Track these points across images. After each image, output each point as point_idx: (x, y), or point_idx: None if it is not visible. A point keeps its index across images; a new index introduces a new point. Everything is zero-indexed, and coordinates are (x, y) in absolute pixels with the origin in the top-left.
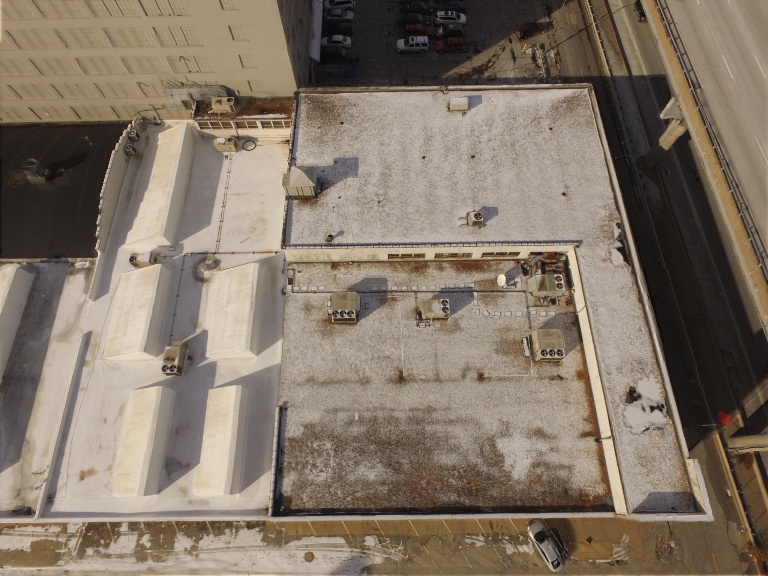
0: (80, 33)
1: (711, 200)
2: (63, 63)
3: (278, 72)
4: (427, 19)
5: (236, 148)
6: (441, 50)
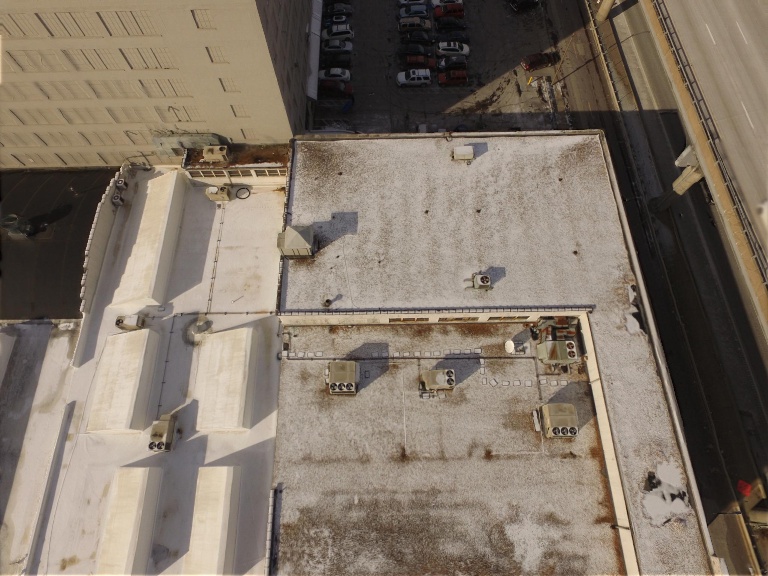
0: (62, 85)
1: (727, 246)
2: (45, 113)
3: (273, 120)
4: (429, 50)
5: (229, 197)
6: (443, 83)
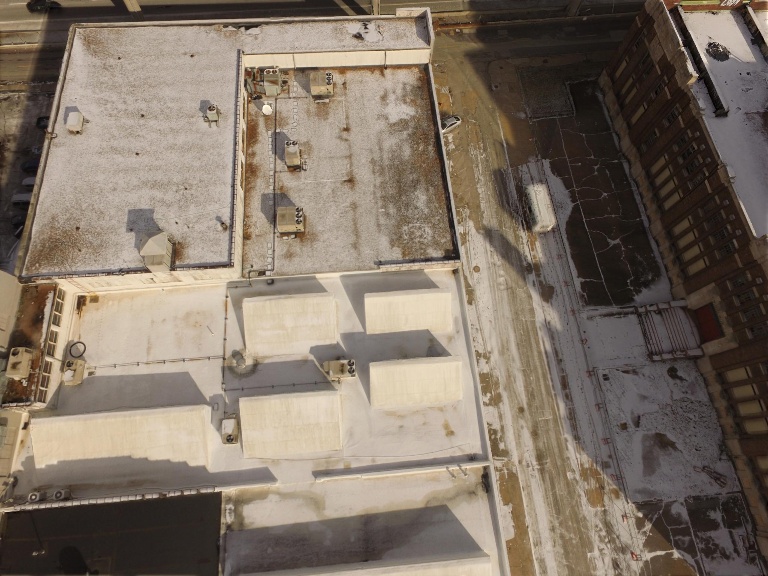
0: None
1: (188, 3)
2: None
3: None
4: None
5: (81, 361)
6: None
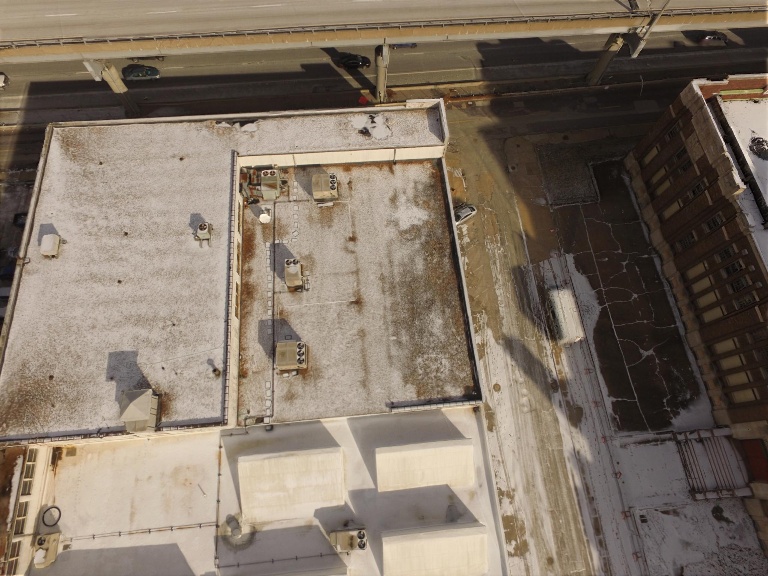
0: None
1: (179, 74)
2: None
3: None
4: None
5: (54, 533)
6: None
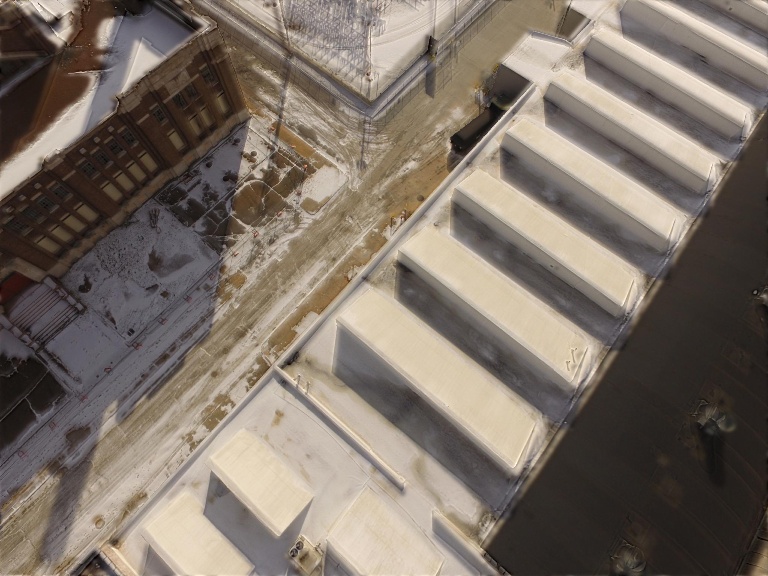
0: None
1: None
2: None
3: None
4: None
5: None
6: None
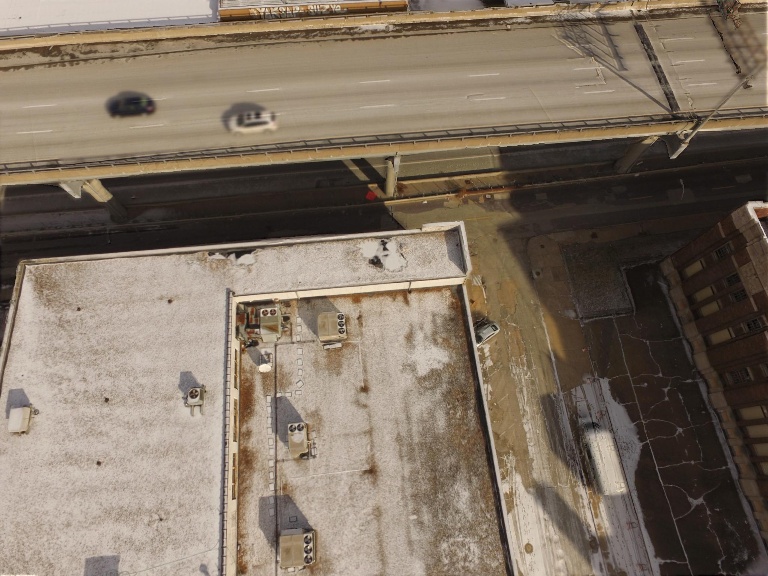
0: None
1: None
2: None
3: None
4: None
5: None
6: None
